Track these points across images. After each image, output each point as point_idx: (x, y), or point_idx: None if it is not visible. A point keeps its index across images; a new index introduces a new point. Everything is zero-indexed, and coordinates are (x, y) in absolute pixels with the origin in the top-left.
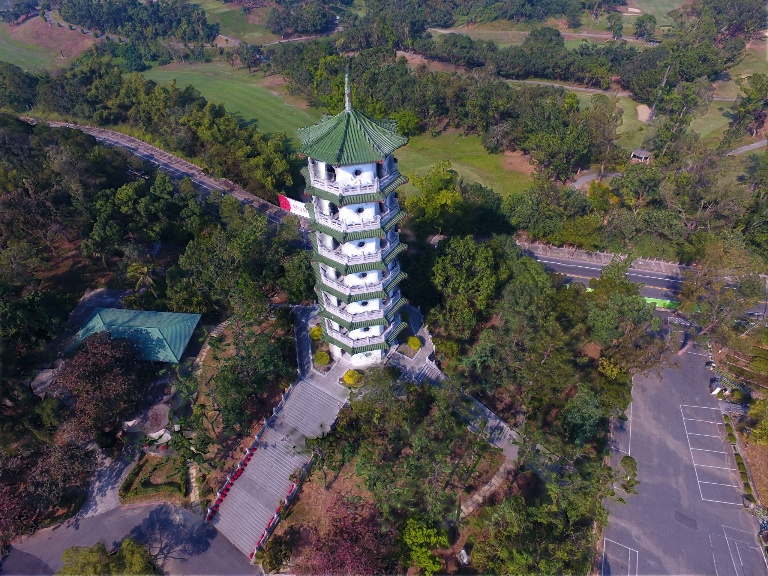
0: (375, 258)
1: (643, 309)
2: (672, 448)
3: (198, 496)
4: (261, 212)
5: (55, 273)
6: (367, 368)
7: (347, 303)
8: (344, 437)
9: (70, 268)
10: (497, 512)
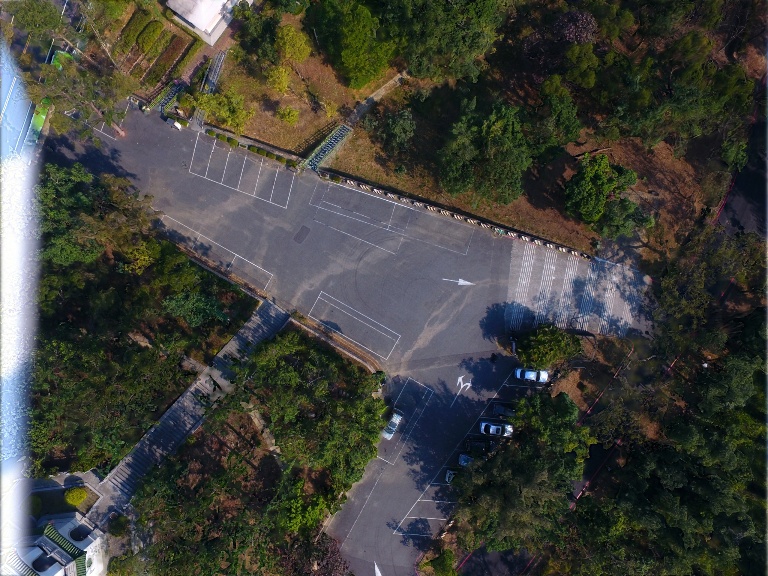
0: None
1: (55, 184)
2: (235, 209)
3: None
4: None
5: None
6: None
7: None
8: (191, 574)
9: None
10: None
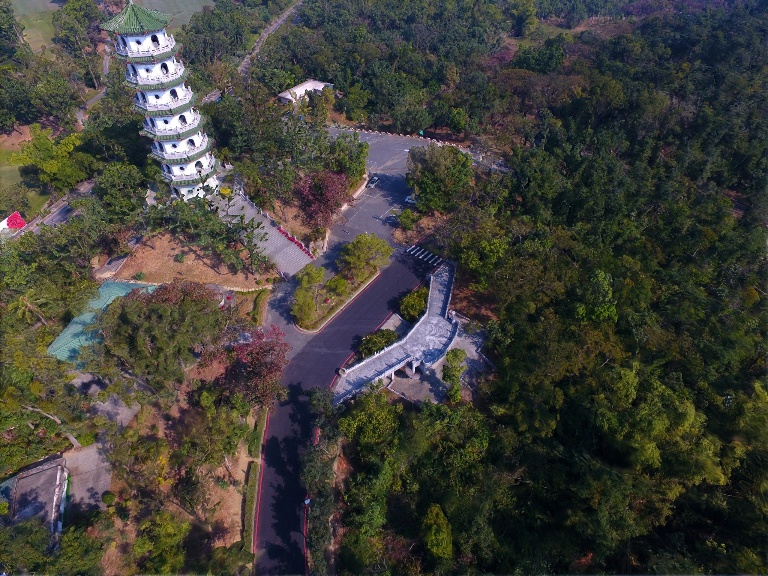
0: (191, 93)
1: None
2: None
3: (269, 286)
4: None
5: None
6: (227, 174)
7: None
8: None
9: None
10: None
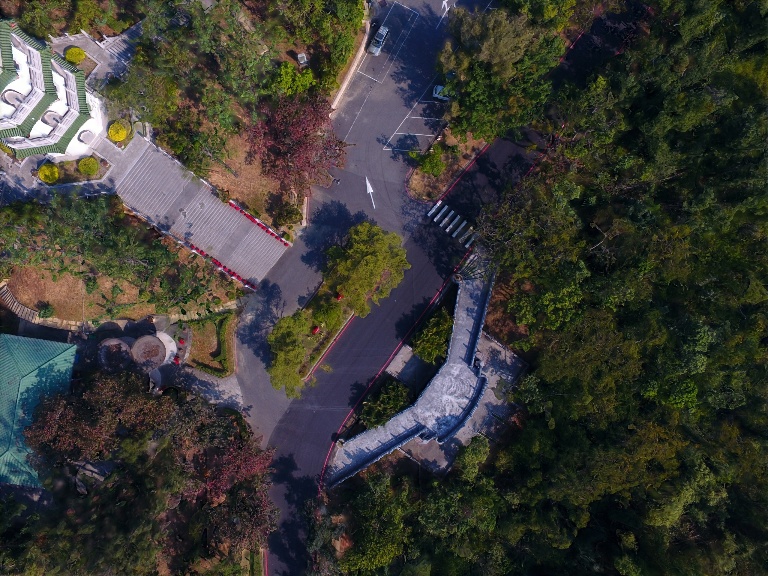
0: None
1: None
2: None
3: (232, 302)
4: None
5: None
6: None
7: (16, 75)
8: None
9: None
10: (269, 25)
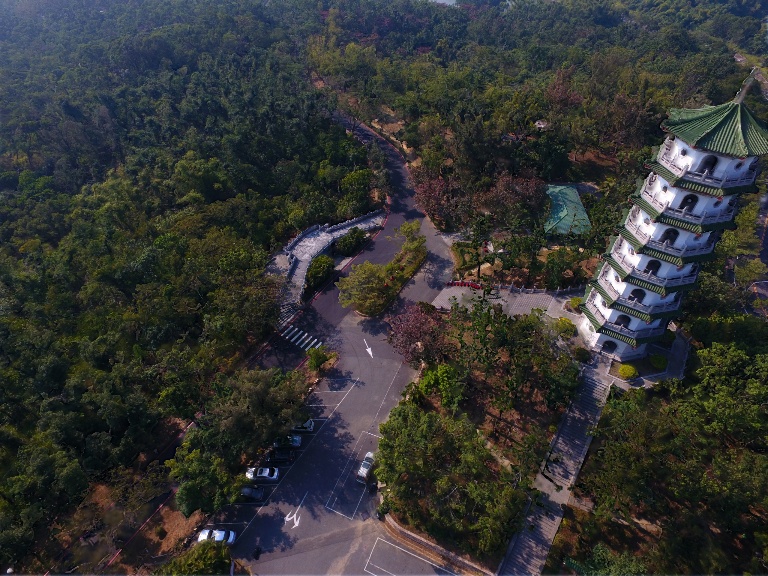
0: (642, 239)
1: None
2: None
3: None
4: (759, 248)
5: (597, 161)
6: None
7: None
8: None
9: (606, 166)
10: None
